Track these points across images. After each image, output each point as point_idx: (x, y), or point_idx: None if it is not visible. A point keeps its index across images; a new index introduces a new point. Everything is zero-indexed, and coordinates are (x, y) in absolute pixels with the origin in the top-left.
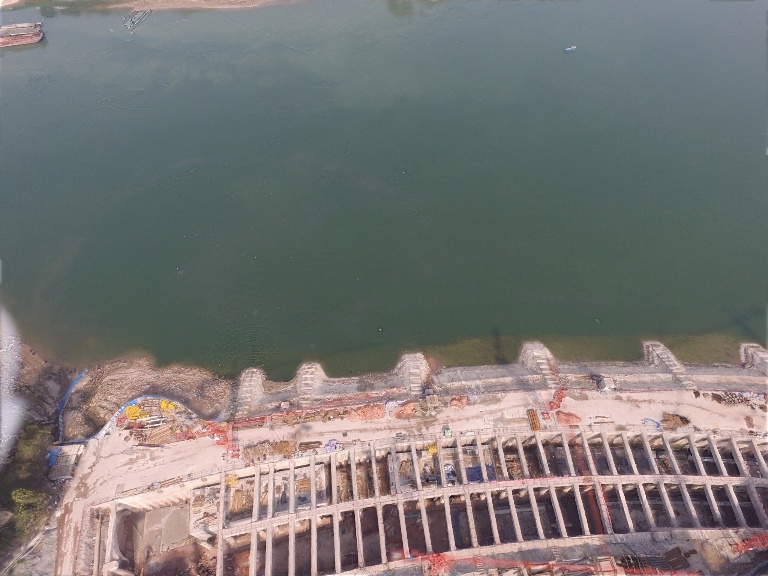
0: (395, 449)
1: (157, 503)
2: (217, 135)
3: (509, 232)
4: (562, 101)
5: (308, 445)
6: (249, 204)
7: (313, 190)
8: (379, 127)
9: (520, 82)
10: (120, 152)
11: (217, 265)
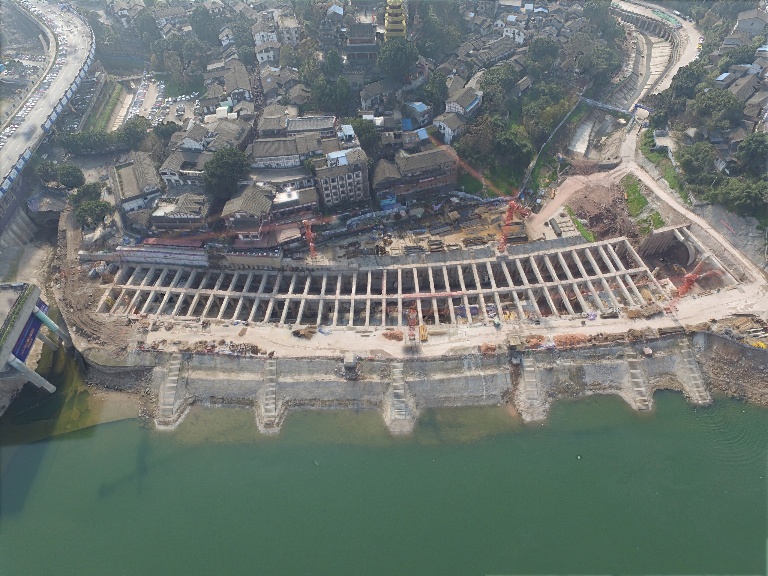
0: None
1: None
2: None
3: None
4: None
5: (611, 315)
6: None
7: None
8: None
9: None
10: None
11: None
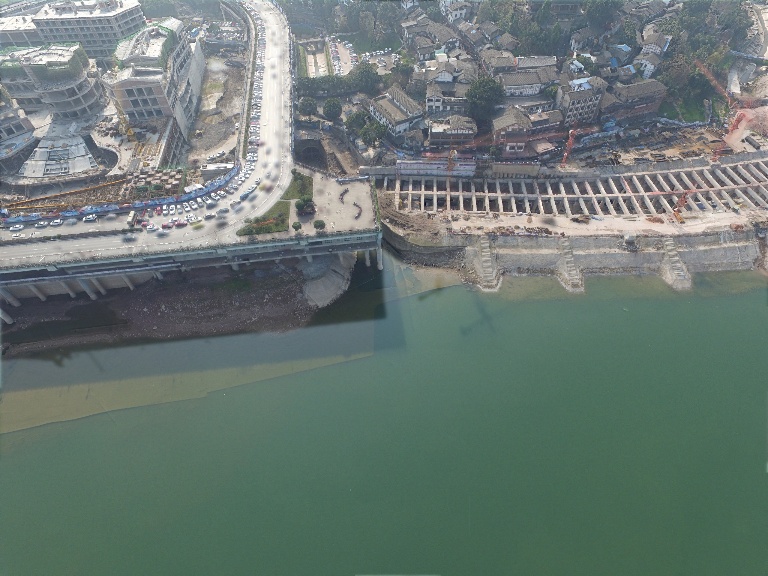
0: None
1: None
2: None
3: (757, 427)
4: None
5: None
6: None
7: None
8: None
9: None
10: None
11: None
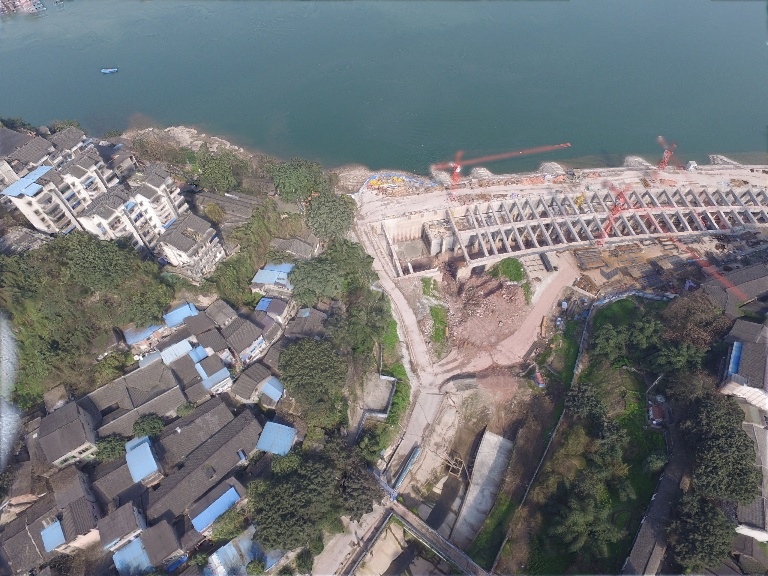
0: (553, 203)
1: (398, 236)
2: (356, 47)
3: (601, 100)
4: (623, 23)
5: (500, 195)
6: (400, 86)
7: (445, 78)
8: (485, 38)
9: (587, 12)
10: (286, 57)
11: (391, 119)
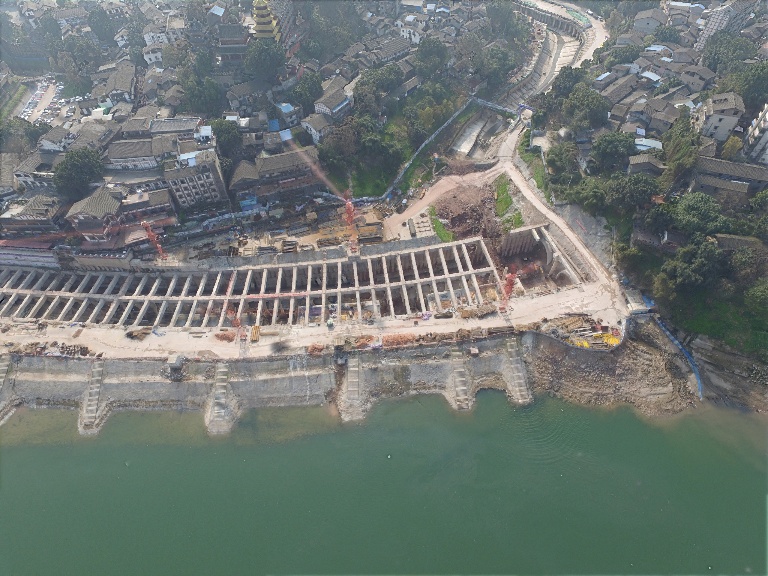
0: None
1: None
2: None
3: None
4: None
5: (445, 315)
6: None
7: None
8: None
9: None
10: None
11: None
